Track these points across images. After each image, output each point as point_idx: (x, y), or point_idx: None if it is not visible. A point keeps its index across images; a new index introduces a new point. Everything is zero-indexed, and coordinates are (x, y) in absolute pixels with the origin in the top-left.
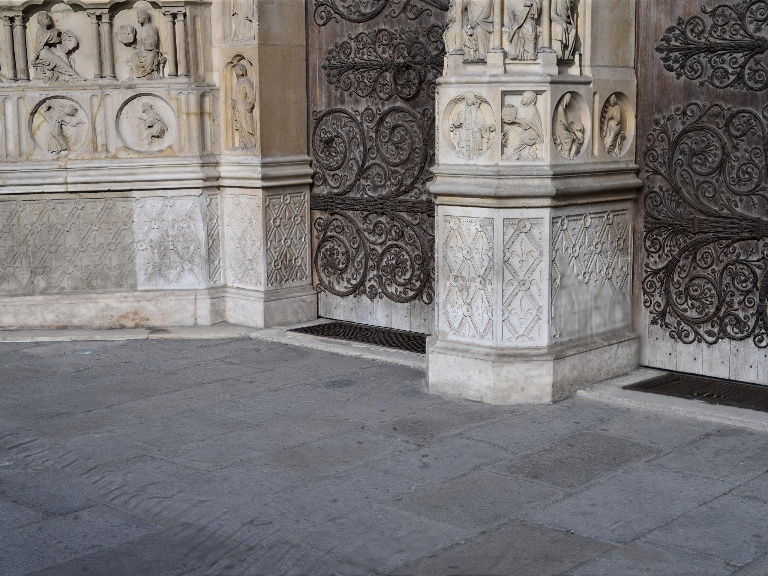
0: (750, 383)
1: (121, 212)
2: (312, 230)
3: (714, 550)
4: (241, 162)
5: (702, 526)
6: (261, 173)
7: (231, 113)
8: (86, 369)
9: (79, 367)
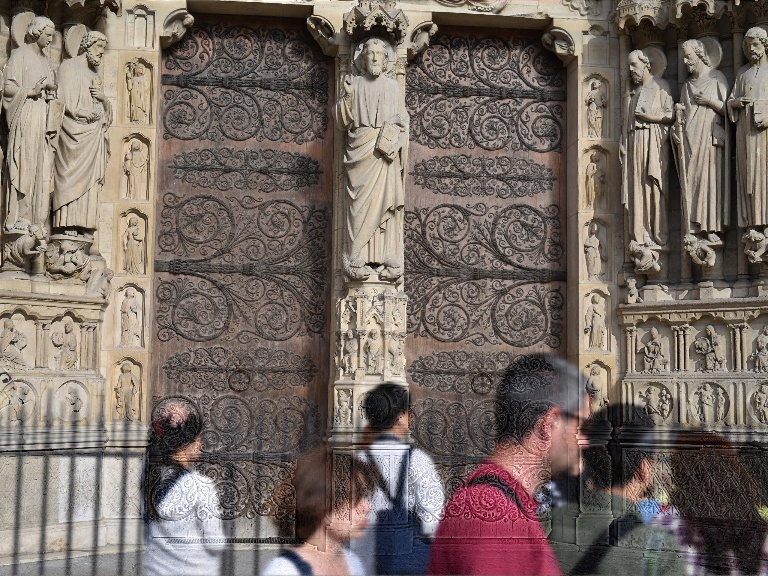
0: (464, 538)
1: (53, 465)
2: (148, 477)
3: (610, 572)
4: (129, 429)
5: (589, 569)
6: (149, 437)
7: (113, 396)
8: (135, 567)
9: (128, 567)
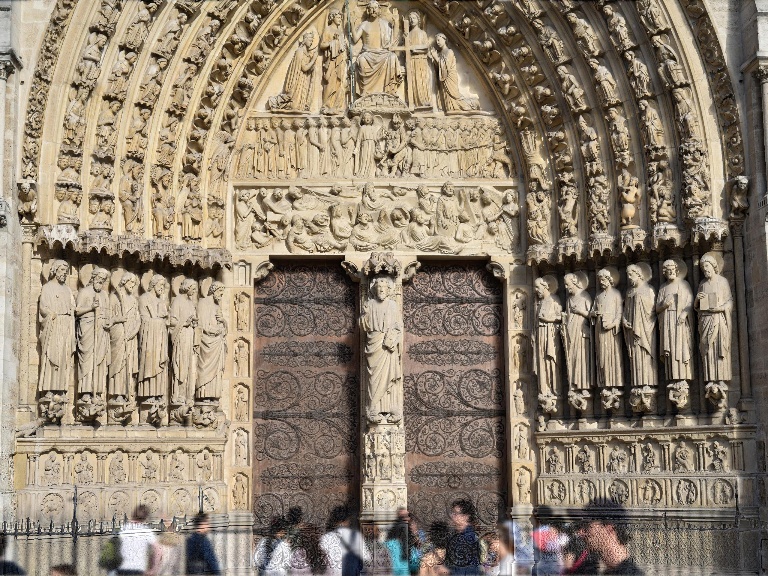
0: None
1: (200, 538)
2: None
3: None
4: (242, 515)
5: None
6: None
7: (232, 495)
8: None
9: None
